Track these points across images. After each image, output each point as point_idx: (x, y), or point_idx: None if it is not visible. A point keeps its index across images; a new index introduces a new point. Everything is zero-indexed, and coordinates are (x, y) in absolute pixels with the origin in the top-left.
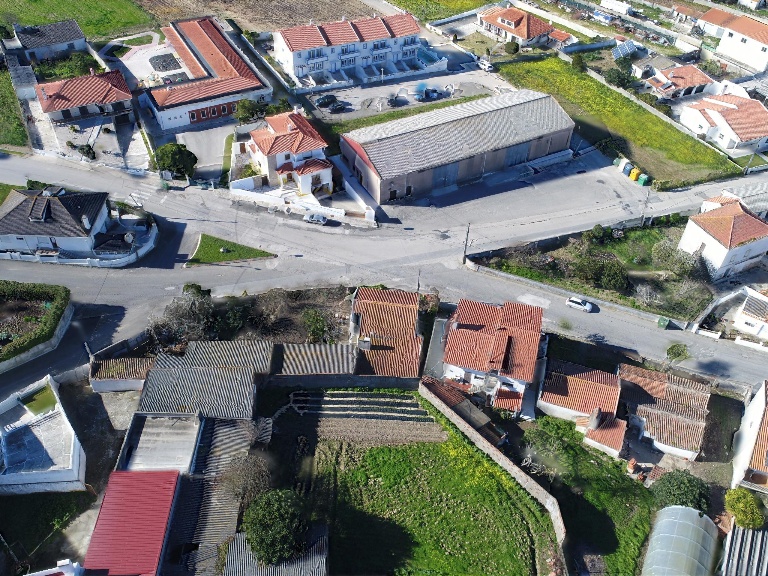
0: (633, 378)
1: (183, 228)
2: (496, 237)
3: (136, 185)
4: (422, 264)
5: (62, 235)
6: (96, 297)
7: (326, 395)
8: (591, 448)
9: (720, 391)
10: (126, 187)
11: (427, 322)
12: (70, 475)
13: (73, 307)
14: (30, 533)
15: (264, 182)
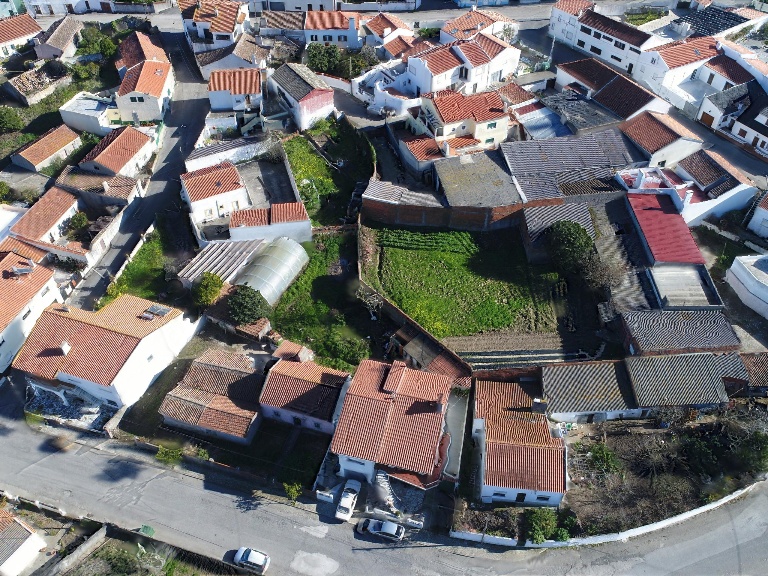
0: (241, 412)
1: None
2: None
3: None
4: None
5: None
6: None
7: None
8: None
9: None
10: None
11: (469, 474)
12: None
13: None
14: (738, 251)
15: None
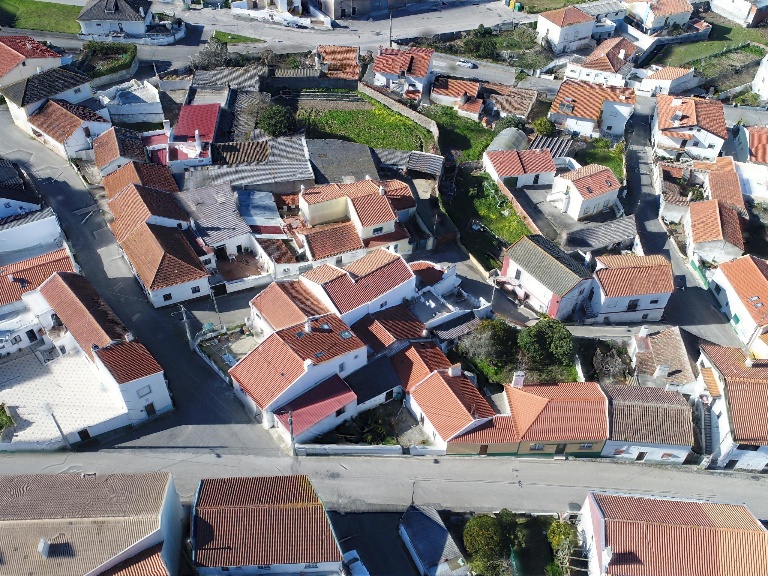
0: (491, 86)
1: (202, 28)
2: (413, 34)
3: (167, 7)
4: (363, 46)
5: (127, 20)
6: (152, 57)
7: (302, 92)
8: (462, 116)
9: (548, 100)
10: (160, 8)
11: None
12: (158, 108)
13: (138, 61)
14: None
15: (254, 5)
